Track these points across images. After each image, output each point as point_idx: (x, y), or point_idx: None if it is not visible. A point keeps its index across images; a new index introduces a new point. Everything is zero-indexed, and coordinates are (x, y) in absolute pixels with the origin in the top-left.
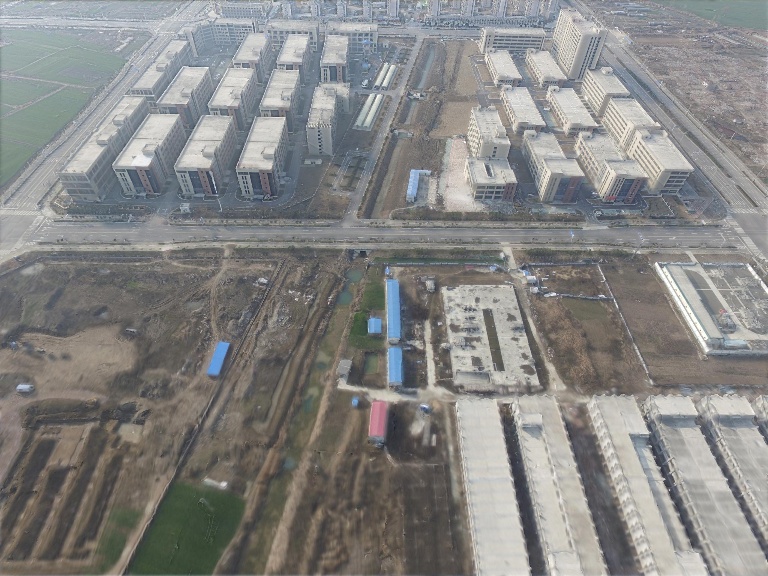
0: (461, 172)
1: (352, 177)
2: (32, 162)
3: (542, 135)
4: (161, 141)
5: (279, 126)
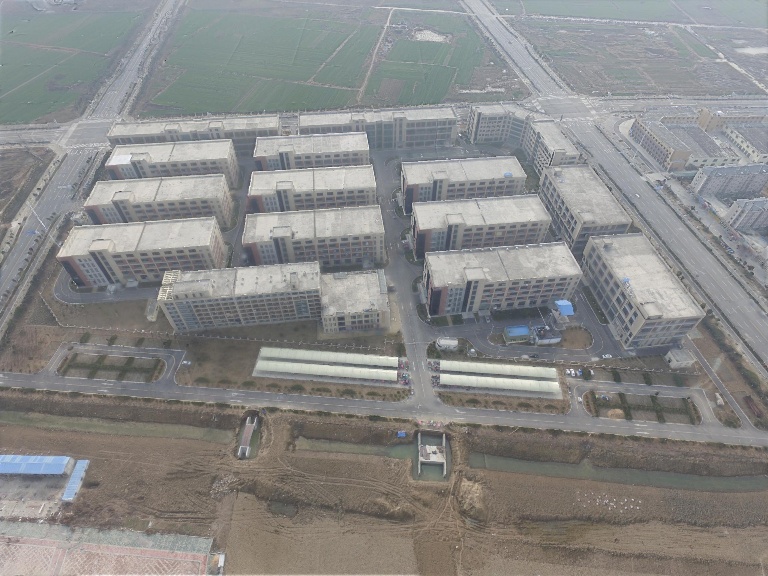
0: (54, 575)
1: (94, 366)
2: (204, 115)
3: None
4: (163, 161)
5: (185, 244)
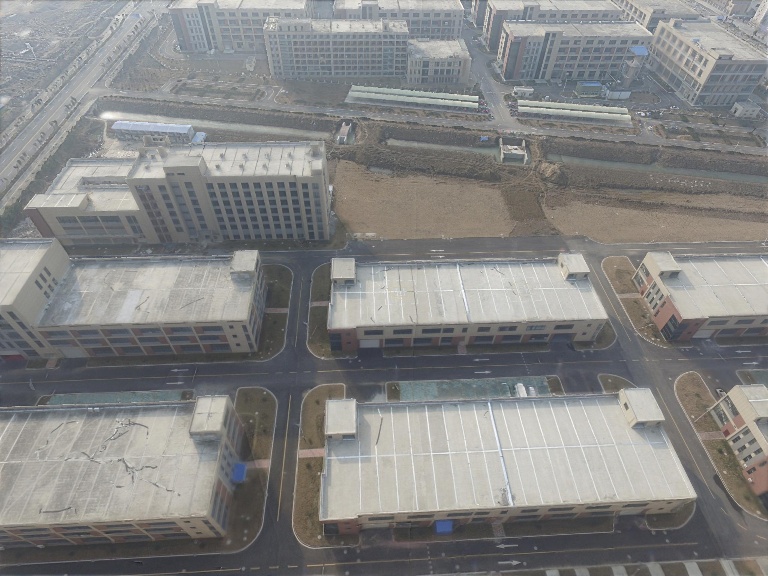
0: None
1: (203, 89)
2: None
3: (243, 294)
4: None
5: None
